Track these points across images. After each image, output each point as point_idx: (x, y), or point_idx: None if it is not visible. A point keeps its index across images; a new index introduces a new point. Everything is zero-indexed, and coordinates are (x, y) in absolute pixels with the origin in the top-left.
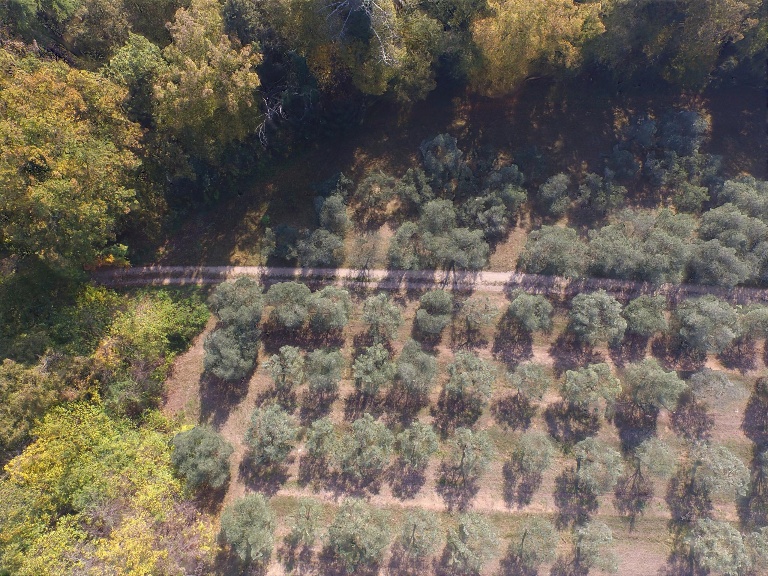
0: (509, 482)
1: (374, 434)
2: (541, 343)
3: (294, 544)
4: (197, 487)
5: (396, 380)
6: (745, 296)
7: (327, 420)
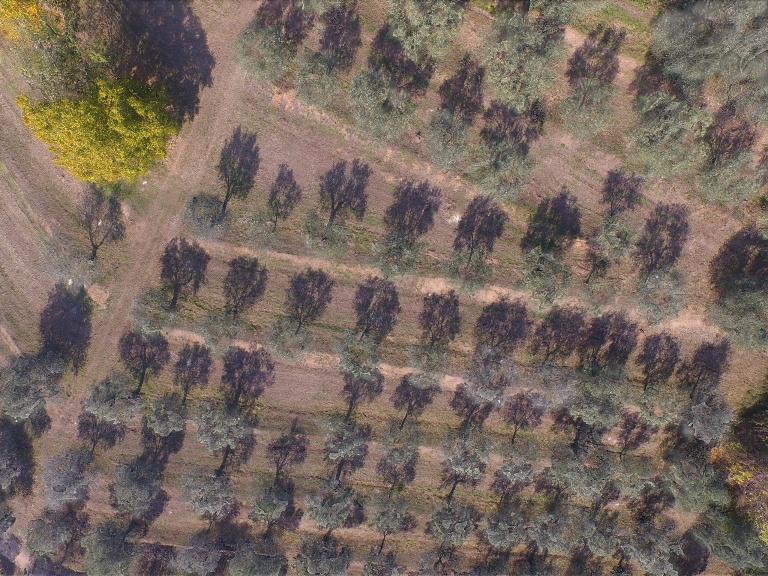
0: (410, 466)
1: (552, 548)
2: (354, 574)
3: (640, 436)
4: (729, 487)
5: (507, 552)
6: None
7: (594, 551)
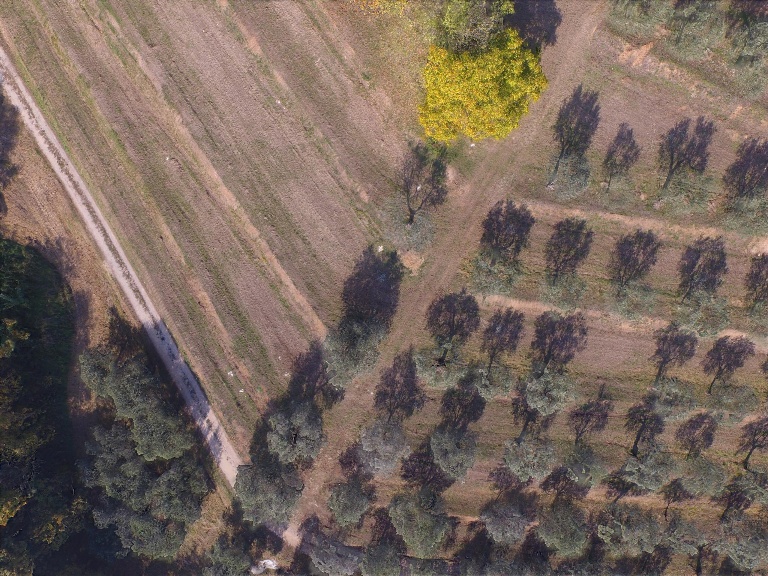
0: (709, 431)
1: None
2: None
3: None
4: None
5: None
6: (407, 570)
7: None
